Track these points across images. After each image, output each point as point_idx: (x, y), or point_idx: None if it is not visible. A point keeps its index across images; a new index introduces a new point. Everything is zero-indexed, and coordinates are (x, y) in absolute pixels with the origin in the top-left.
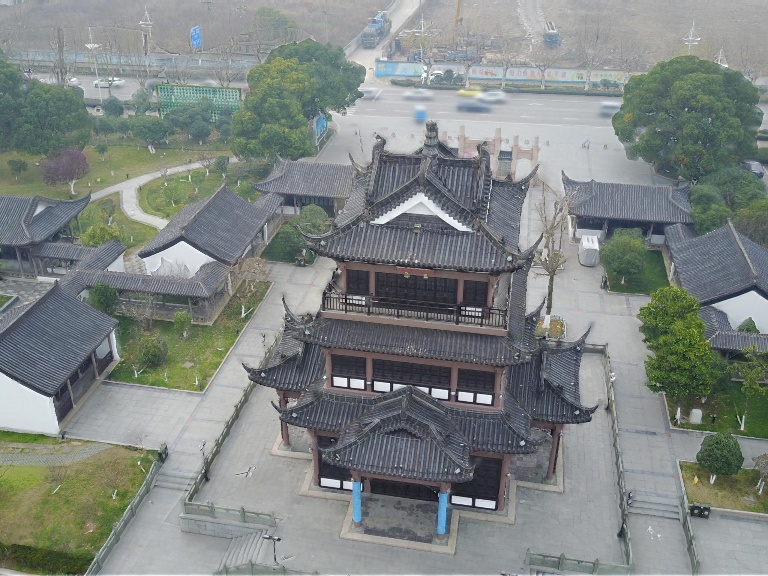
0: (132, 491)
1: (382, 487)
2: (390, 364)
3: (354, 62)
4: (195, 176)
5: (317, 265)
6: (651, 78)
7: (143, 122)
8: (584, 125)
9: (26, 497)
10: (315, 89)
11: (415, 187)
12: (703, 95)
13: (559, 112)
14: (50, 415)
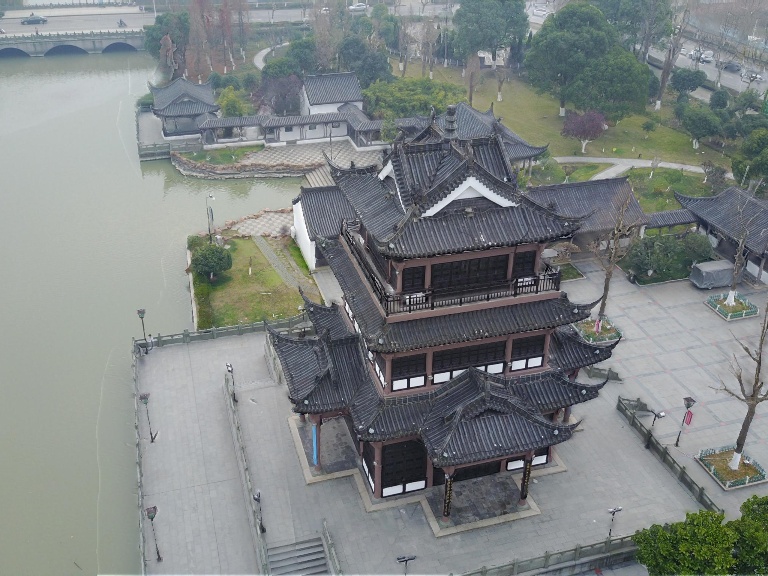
0: None
1: None
2: None
3: None
4: (670, 173)
5: (645, 288)
6: None
7: (692, 113)
8: None
9: (253, 287)
10: None
11: None
12: None
13: None
14: (310, 254)
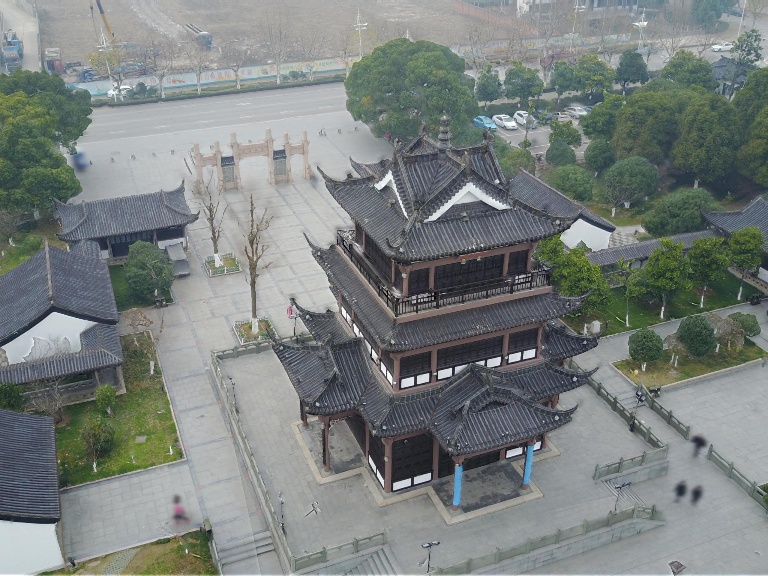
0: None
1: (448, 469)
2: (452, 350)
3: (73, 87)
4: None
5: (178, 301)
6: (377, 62)
7: None
8: (305, 115)
9: None
10: (56, 122)
11: (461, 179)
12: (437, 70)
13: (271, 108)
14: (55, 545)
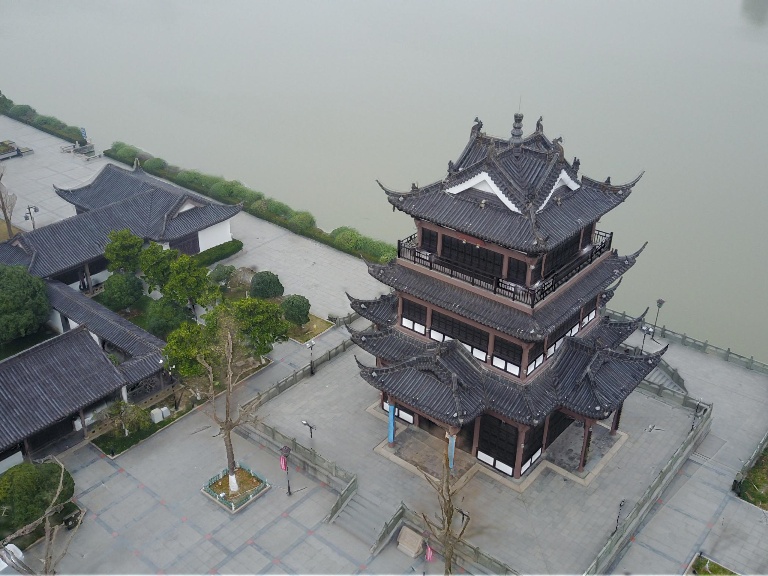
0: (763, 474)
1: None
2: None
3: None
4: None
5: None
6: None
7: None
8: None
9: None
10: None
11: None
12: None
13: None
14: None
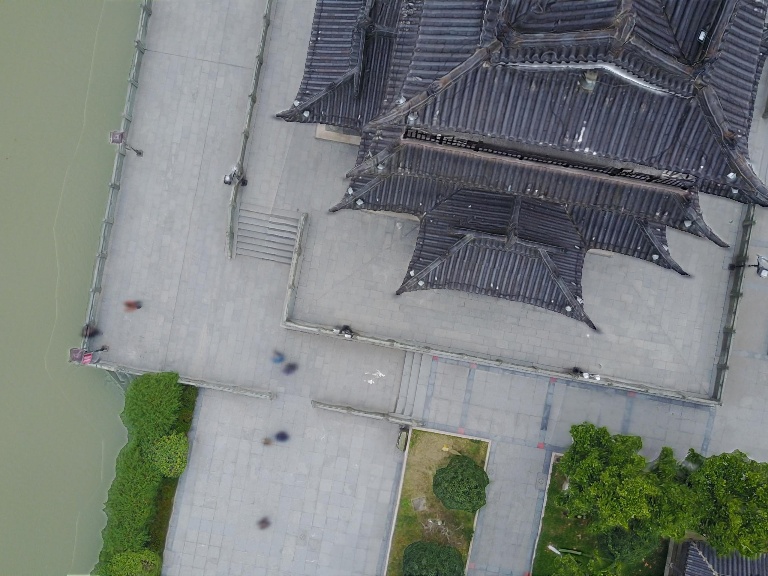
0: None
1: None
2: None
3: None
4: None
5: None
6: None
7: None
8: None
9: None
10: None
11: None
12: None
13: None
14: None
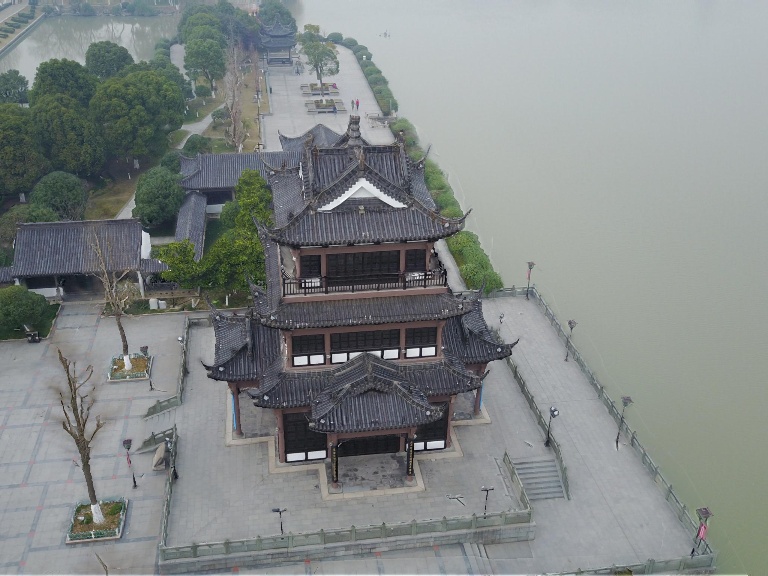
0: None
1: None
2: None
3: None
4: None
5: None
6: None
7: None
8: None
9: None
10: None
11: None
12: None
13: None
14: None
